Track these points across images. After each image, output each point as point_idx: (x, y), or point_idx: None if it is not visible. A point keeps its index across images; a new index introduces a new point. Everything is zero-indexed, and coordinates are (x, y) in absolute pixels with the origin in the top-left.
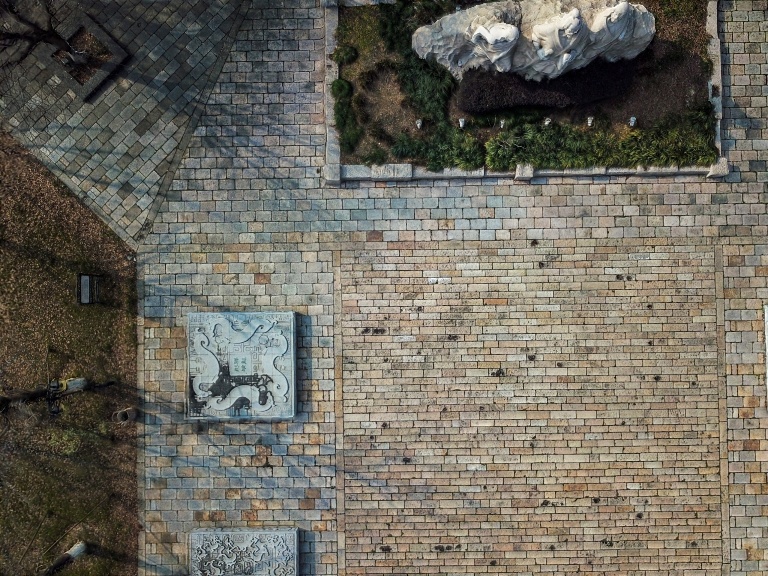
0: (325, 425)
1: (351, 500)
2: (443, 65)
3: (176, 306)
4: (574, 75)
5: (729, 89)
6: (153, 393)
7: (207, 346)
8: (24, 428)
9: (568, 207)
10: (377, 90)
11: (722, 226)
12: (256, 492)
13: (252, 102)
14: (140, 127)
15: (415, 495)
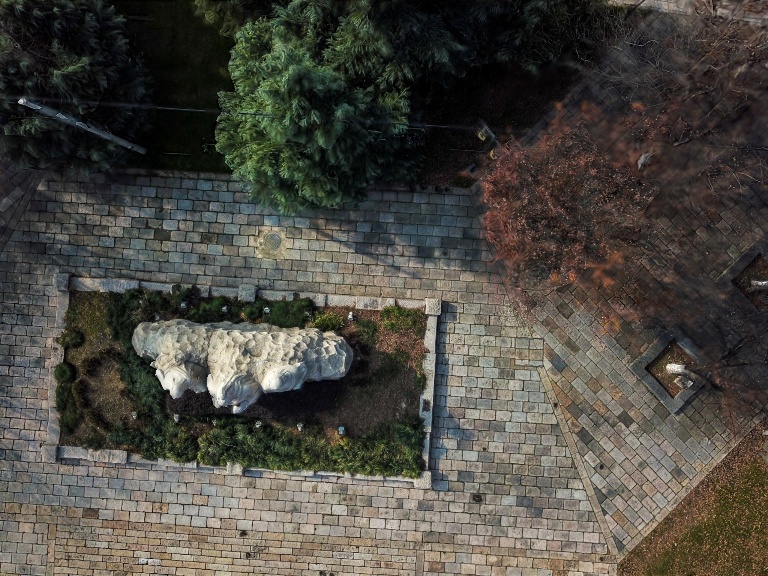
0: None
1: None
2: None
3: None
4: None
5: (445, 399)
6: None
7: None
8: None
9: (279, 501)
10: (100, 376)
11: (426, 532)
12: None
13: None
14: None
15: None
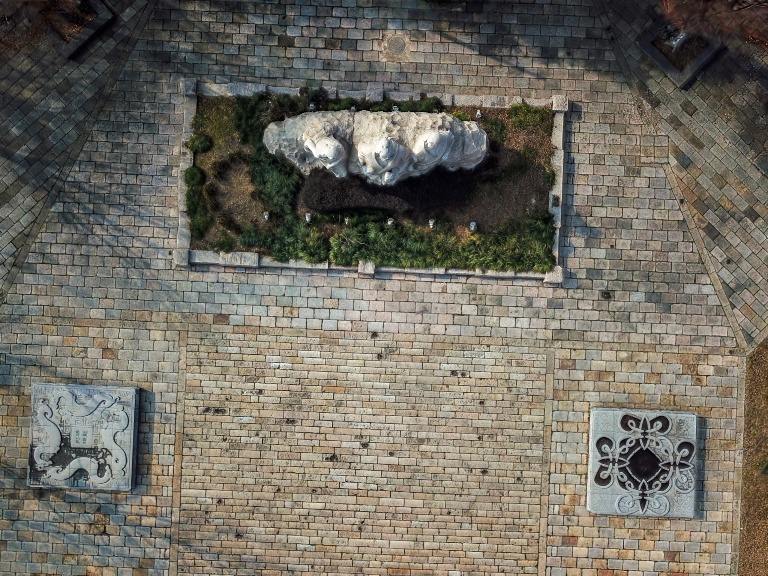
0: (163, 499)
1: (183, 572)
2: (292, 161)
3: (25, 375)
4: (415, 180)
5: (572, 198)
6: None
7: (50, 417)
8: None
9: (409, 303)
10: (230, 179)
11: (556, 330)
12: (92, 559)
13: (110, 182)
14: None
15: (245, 571)
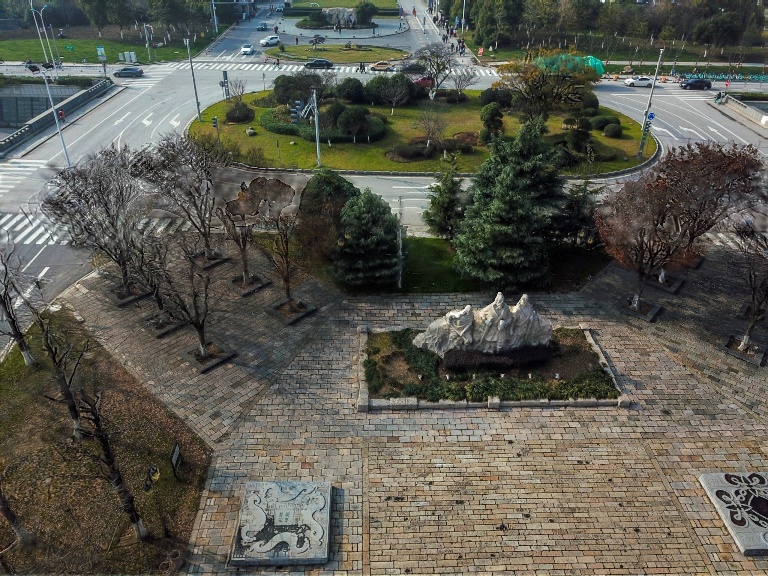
0: (353, 572)
1: None
2: (432, 351)
3: (237, 483)
4: (513, 351)
5: (614, 367)
6: (202, 547)
7: (259, 504)
8: (77, 572)
9: (529, 423)
10: (392, 365)
11: (642, 433)
12: None
13: (311, 373)
14: (235, 384)
15: None
